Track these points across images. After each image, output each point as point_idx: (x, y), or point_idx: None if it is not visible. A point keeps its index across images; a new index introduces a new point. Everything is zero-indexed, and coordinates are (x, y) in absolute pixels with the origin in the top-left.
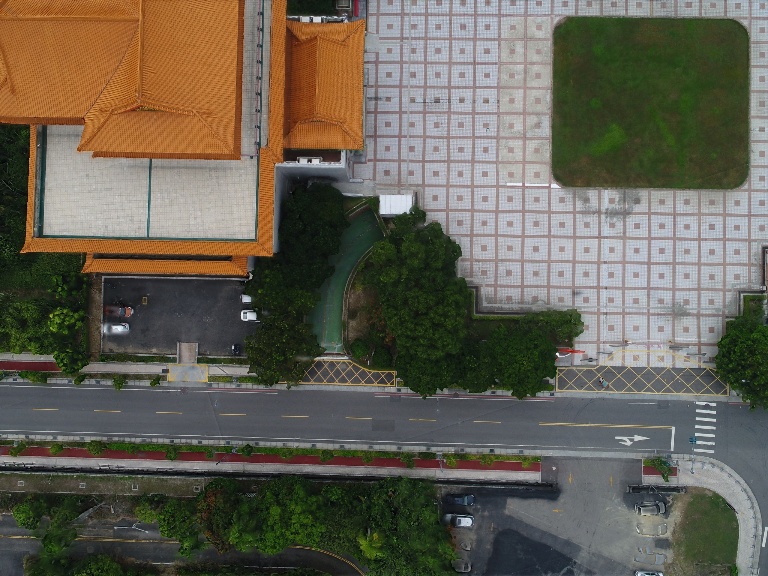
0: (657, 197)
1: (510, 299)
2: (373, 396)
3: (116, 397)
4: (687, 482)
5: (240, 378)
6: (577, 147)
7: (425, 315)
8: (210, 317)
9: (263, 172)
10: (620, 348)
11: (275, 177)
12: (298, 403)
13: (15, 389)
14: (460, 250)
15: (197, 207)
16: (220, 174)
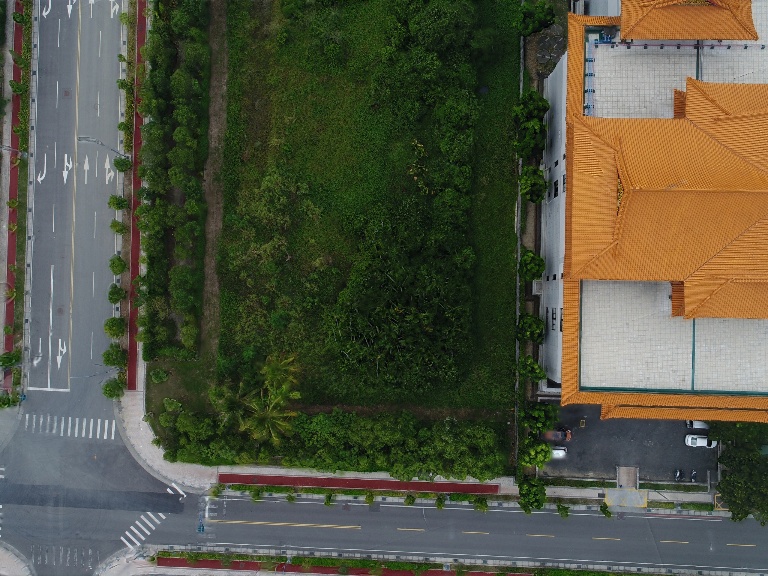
0: None
1: None
2: None
3: (549, 521)
4: None
5: (684, 505)
6: None
7: None
8: (651, 441)
9: None
10: None
11: None
12: (744, 531)
13: (442, 511)
14: None
15: (746, 359)
16: None
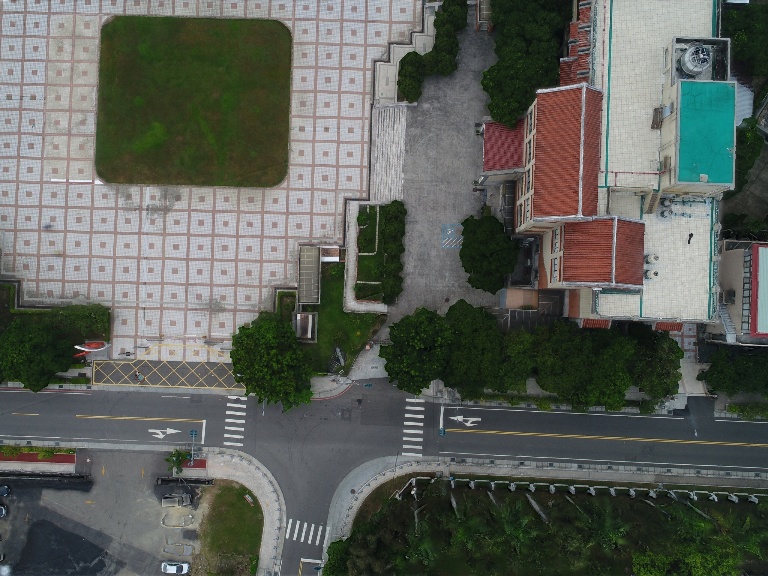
0: (197, 194)
1: (51, 293)
2: None
3: None
4: (216, 474)
5: None
6: (120, 144)
7: None
8: None
9: None
10: (157, 342)
11: None
12: None
13: None
14: None
15: None
16: None
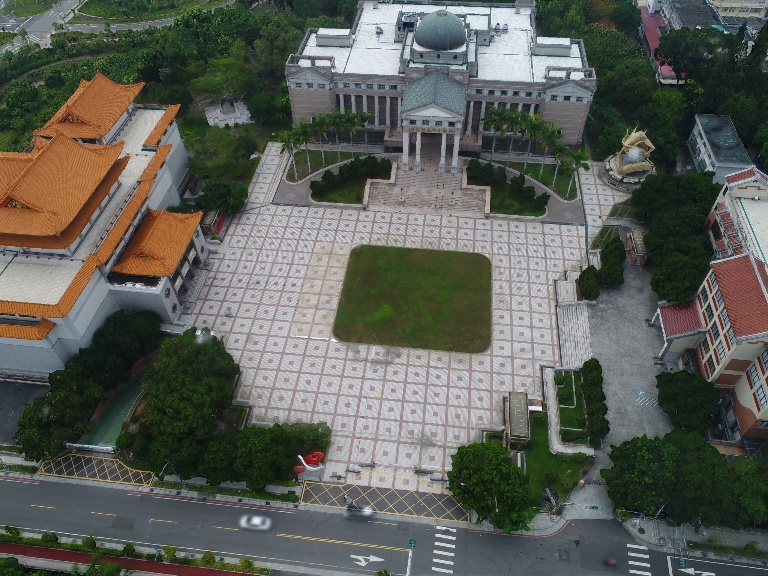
0: (415, 354)
1: (277, 419)
2: (126, 494)
3: None
4: None
5: (11, 465)
6: (355, 317)
7: (178, 391)
8: (14, 412)
9: (85, 268)
10: (368, 469)
11: (106, 295)
12: (53, 494)
13: None
14: (238, 369)
15: (28, 286)
16: (56, 269)
